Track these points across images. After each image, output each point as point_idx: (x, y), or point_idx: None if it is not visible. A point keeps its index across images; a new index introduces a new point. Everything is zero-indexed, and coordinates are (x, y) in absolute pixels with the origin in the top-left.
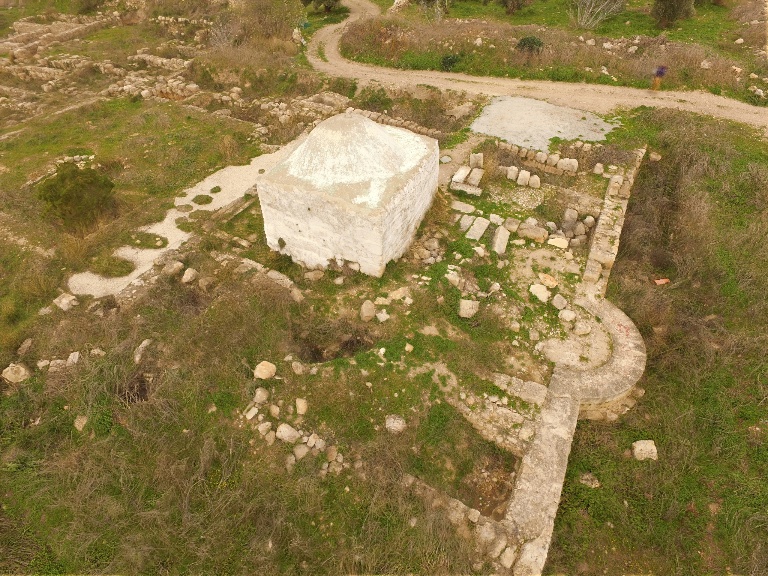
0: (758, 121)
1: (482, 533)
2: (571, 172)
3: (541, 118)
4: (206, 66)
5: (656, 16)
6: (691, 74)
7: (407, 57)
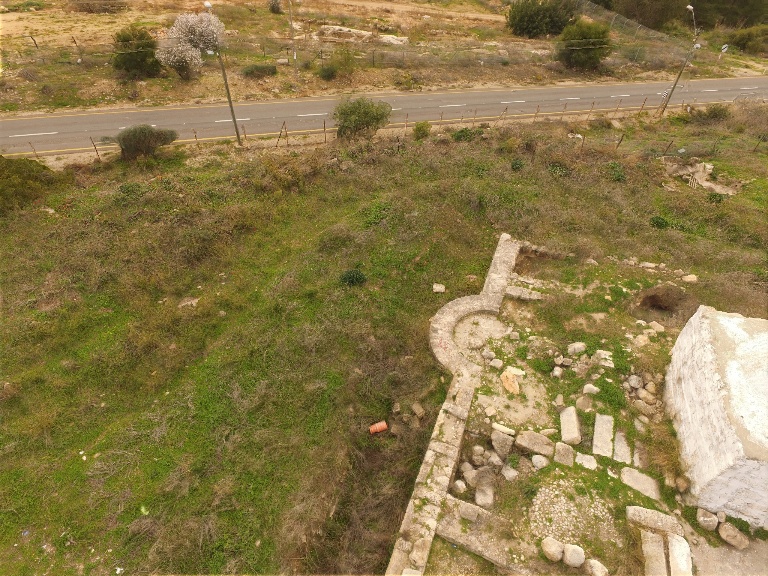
0: None
1: None
2: None
3: None
4: None
5: None
6: None
7: None
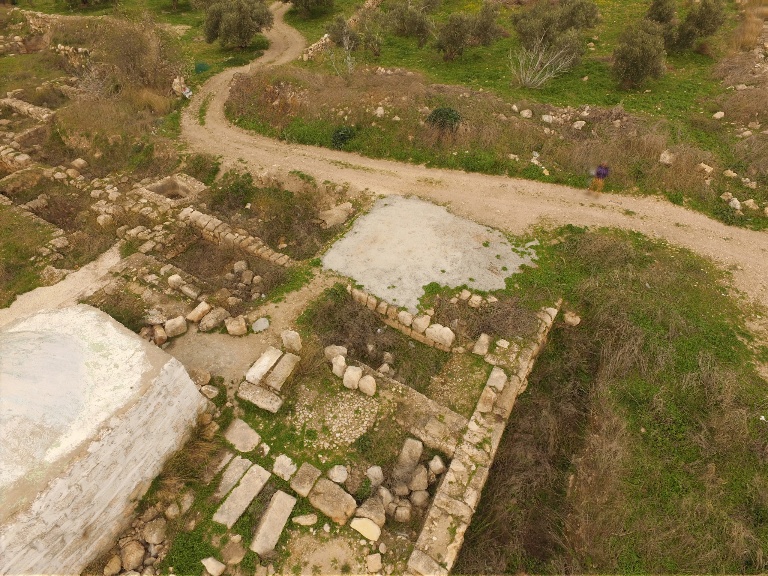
0: (728, 255)
1: None
2: (444, 346)
3: (427, 242)
4: (57, 126)
5: (616, 76)
6: (646, 171)
7: (294, 126)
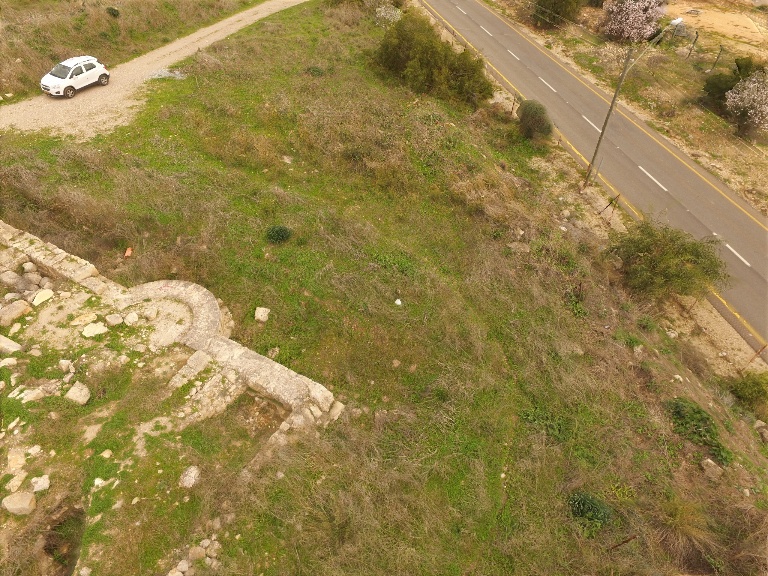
0: (1, 124)
1: (298, 423)
2: None
3: None
4: None
5: None
6: None
7: None
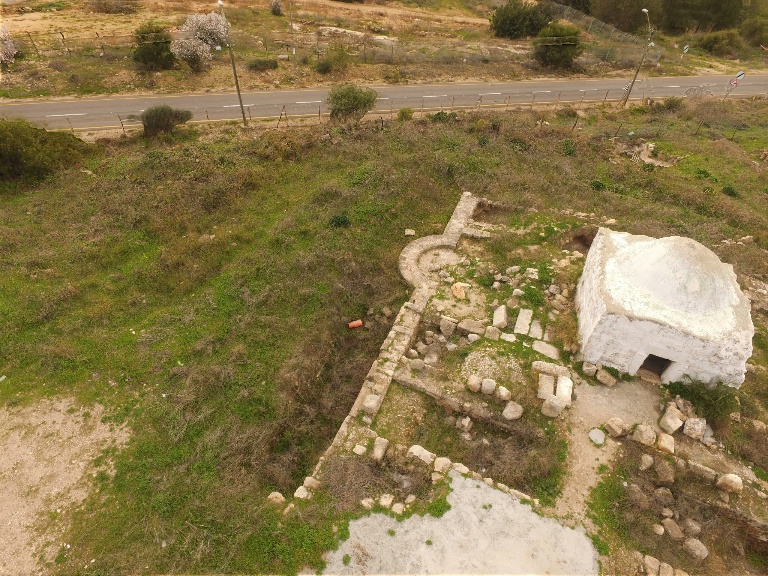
0: None
1: None
2: None
3: None
4: None
5: None
6: None
7: None
